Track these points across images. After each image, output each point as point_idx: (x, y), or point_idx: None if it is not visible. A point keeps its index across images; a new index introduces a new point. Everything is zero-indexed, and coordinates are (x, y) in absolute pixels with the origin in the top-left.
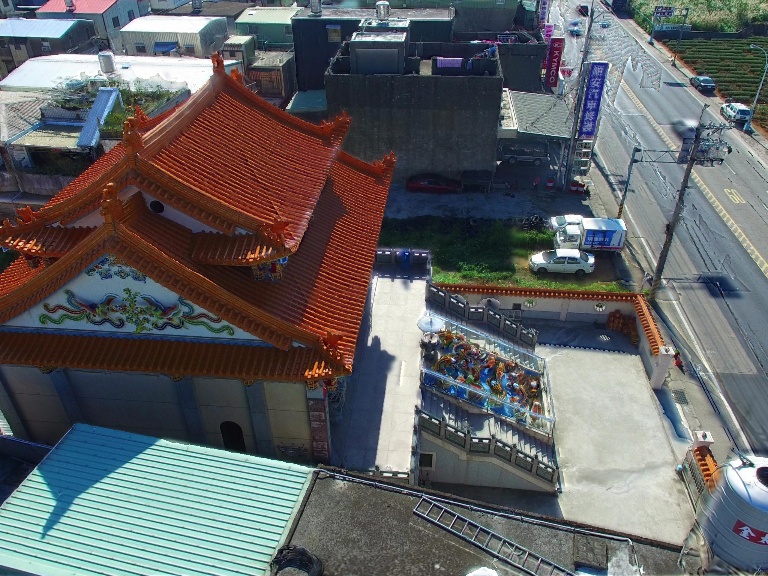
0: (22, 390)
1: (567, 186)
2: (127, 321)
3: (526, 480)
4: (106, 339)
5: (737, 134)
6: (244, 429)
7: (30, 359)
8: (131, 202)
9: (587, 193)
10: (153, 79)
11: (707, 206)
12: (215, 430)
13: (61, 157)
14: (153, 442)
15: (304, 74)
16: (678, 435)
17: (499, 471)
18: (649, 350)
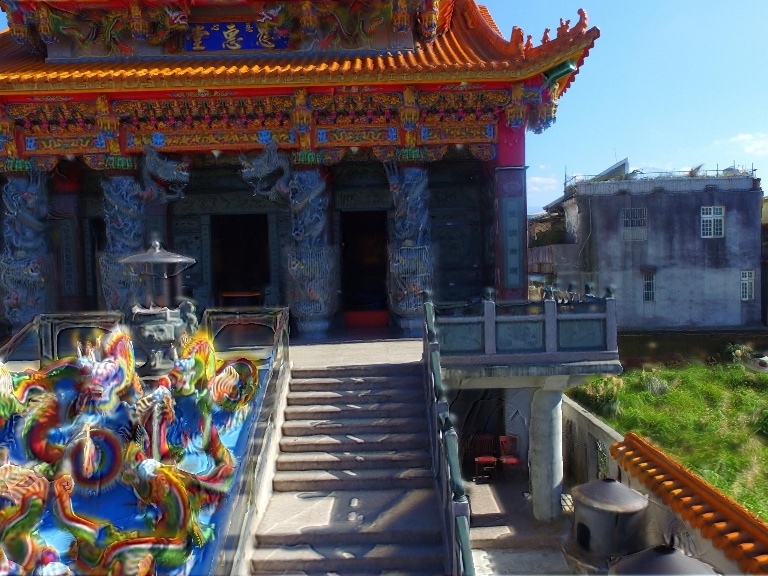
0: None
1: None
2: None
3: None
4: None
5: None
6: None
7: None
8: None
9: None
10: (728, 173)
11: None
12: None
13: None
14: None
15: None
16: None
17: None
18: None
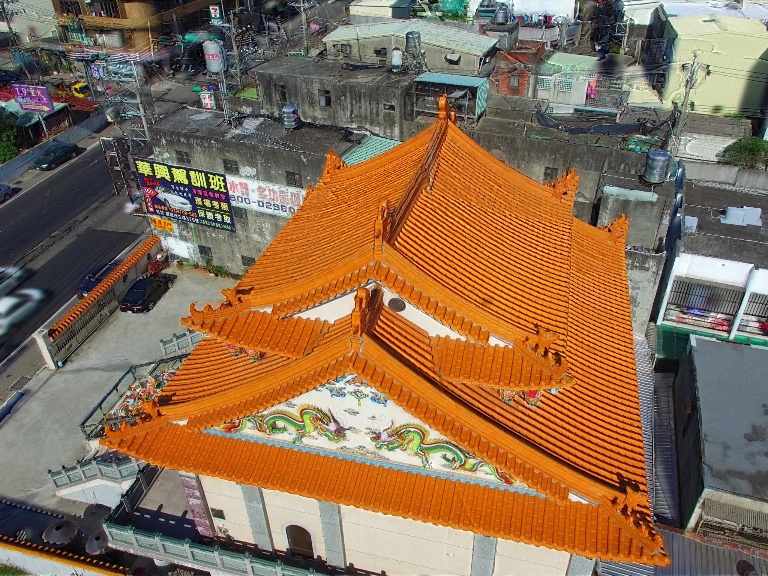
0: None
1: None
2: None
3: None
4: None
5: None
6: None
7: None
8: None
9: None
10: None
11: None
12: None
13: None
14: None
15: None
16: (24, 395)
17: None
18: None
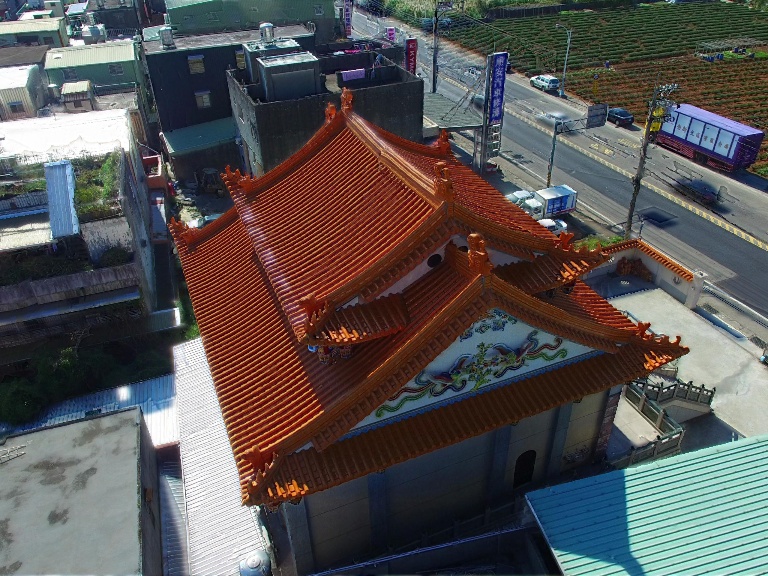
0: (321, 510)
1: (484, 169)
2: (469, 380)
3: (693, 410)
4: (446, 408)
5: (558, 100)
6: (538, 453)
7: (391, 459)
8: None
9: (500, 172)
10: (74, 144)
11: (592, 161)
12: (511, 466)
13: (12, 259)
14: (622, 475)
15: (167, 113)
16: (736, 337)
17: (676, 411)
18: (673, 280)
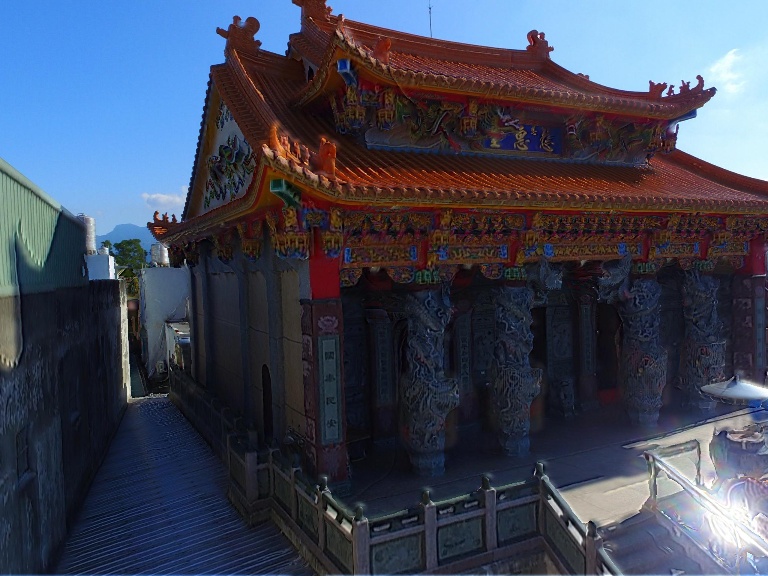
0: None
1: None
2: None
3: None
4: None
5: None
6: None
7: None
8: (280, 58)
9: None
10: None
11: None
12: (259, 383)
13: None
14: None
15: None
16: None
17: None
18: None
